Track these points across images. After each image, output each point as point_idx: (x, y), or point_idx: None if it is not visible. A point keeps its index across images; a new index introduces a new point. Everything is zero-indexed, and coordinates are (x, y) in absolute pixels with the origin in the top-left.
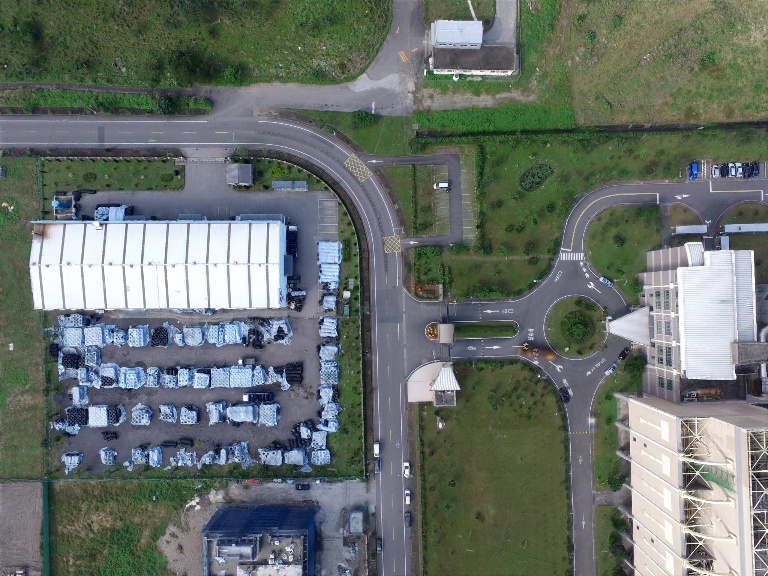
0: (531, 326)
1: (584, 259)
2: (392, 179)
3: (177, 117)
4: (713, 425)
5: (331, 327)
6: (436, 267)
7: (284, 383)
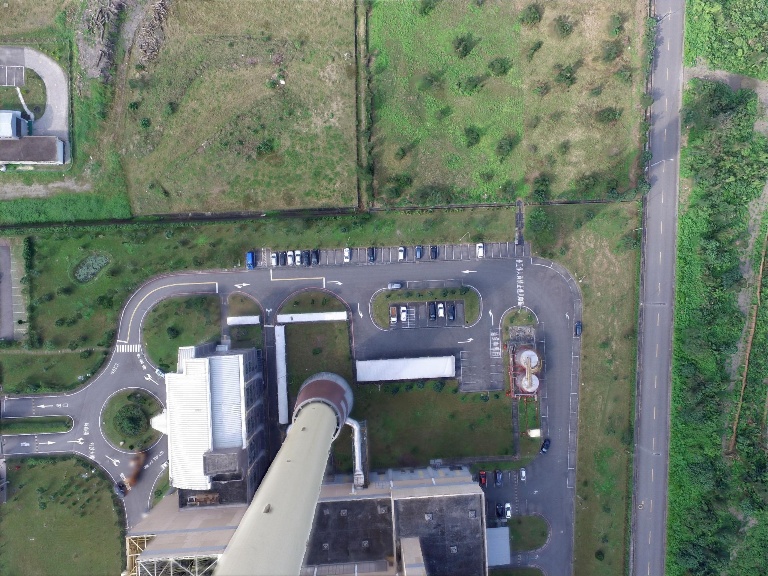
0: (86, 420)
1: (141, 351)
2: None
3: None
4: None
5: None
6: None
7: None
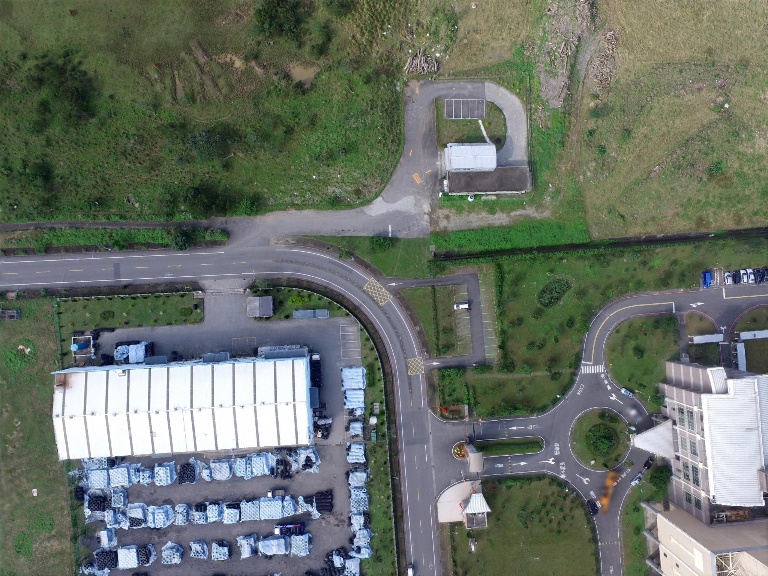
0: (556, 441)
1: (605, 371)
2: (412, 301)
3: (193, 249)
4: (747, 560)
5: (359, 453)
6: (460, 387)
7: (314, 512)
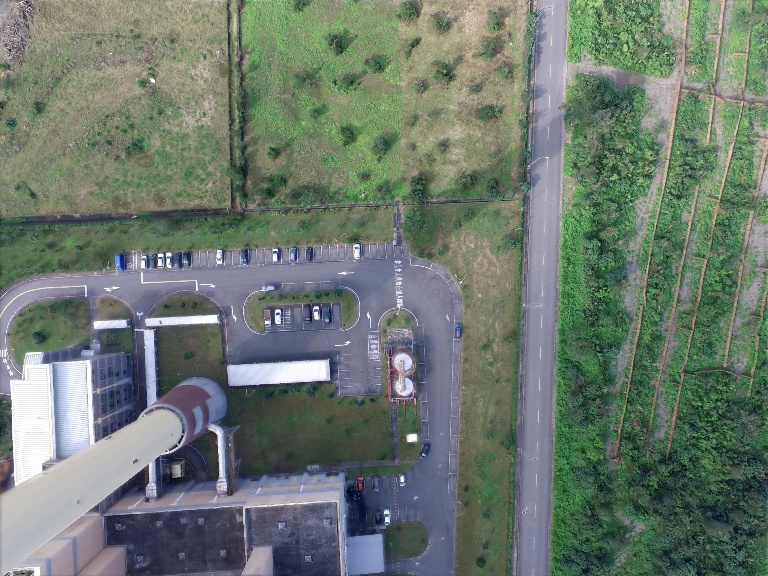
0: None
1: (8, 356)
2: None
3: None
4: None
5: None
6: None
7: None
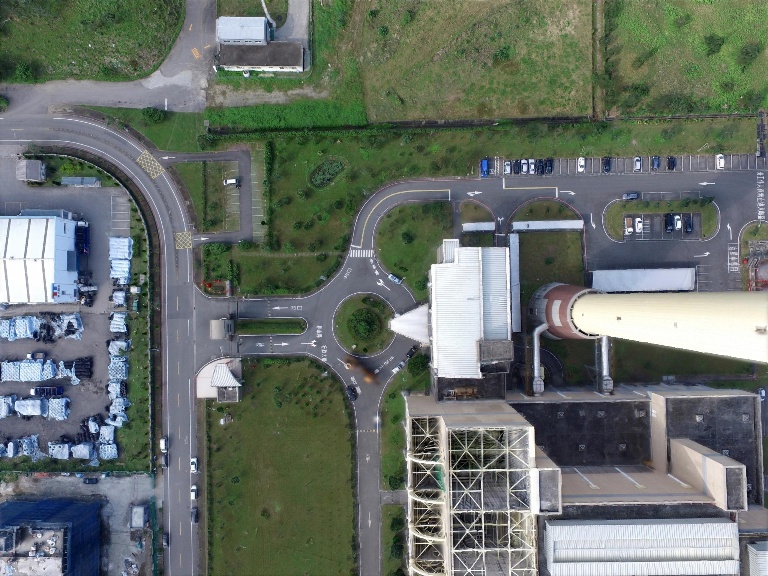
0: (319, 323)
1: (374, 256)
2: (184, 175)
3: None
4: None
5: (120, 322)
6: (226, 263)
7: (73, 377)
